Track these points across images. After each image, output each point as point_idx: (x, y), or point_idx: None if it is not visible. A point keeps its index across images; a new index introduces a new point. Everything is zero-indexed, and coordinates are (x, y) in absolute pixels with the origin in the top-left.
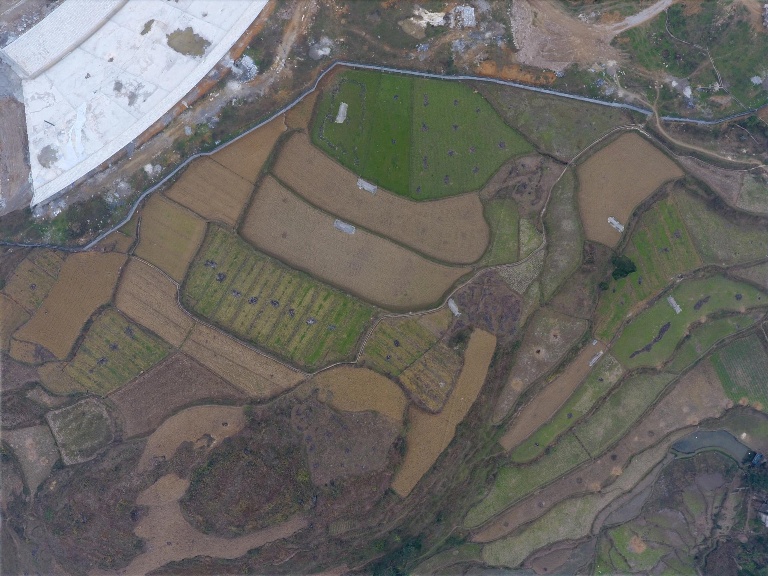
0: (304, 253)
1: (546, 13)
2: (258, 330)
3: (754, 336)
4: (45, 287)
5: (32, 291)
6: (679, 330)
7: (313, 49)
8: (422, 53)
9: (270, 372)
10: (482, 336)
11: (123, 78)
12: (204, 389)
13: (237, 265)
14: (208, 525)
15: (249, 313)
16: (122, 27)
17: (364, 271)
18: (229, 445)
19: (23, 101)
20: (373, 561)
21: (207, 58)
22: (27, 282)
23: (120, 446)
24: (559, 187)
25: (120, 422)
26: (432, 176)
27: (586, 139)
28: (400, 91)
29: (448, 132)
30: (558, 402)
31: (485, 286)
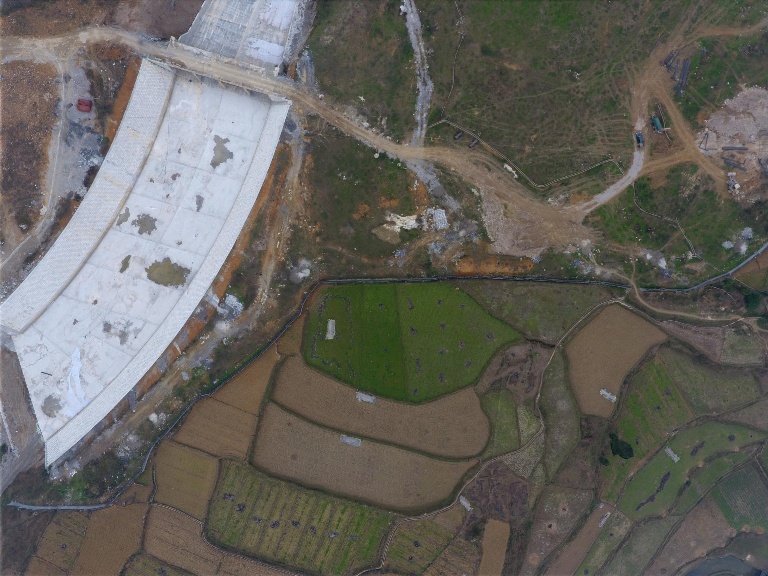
0: (316, 471)
1: (516, 203)
2: (284, 551)
3: (750, 466)
4: (75, 546)
5: (64, 551)
6: (679, 477)
7: (293, 273)
8: (400, 259)
9: None
10: (496, 525)
11: (110, 318)
12: None
13: (254, 494)
14: None
15: (273, 537)
16: (100, 268)
17: (375, 479)
18: None
19: None
20: None
21: (190, 289)
22: (57, 544)
23: None
24: (550, 370)
25: None
26: (427, 377)
27: (570, 319)
28: (384, 299)
29: (436, 332)
30: (574, 565)
31: (492, 477)
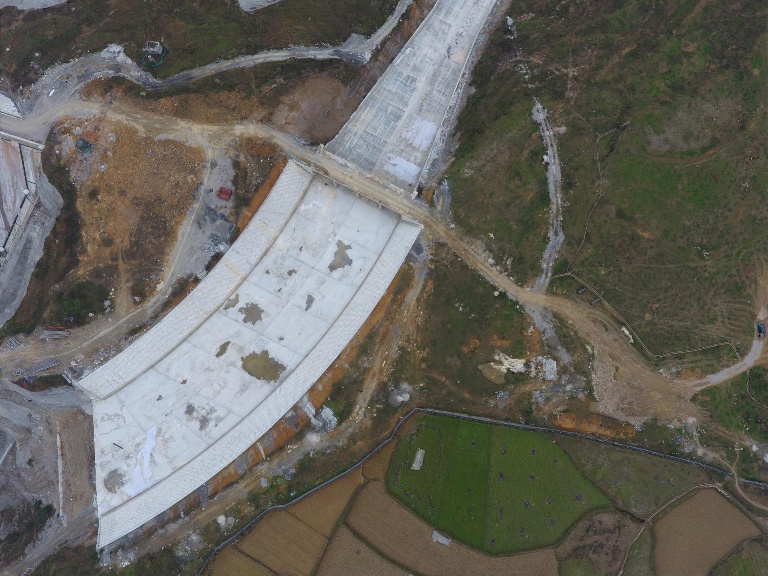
0: None
1: (627, 368)
2: None
3: None
4: None
5: None
6: None
7: (393, 395)
8: (501, 400)
9: None
10: None
11: (195, 401)
12: None
13: None
14: None
15: None
16: (197, 348)
17: None
18: None
19: (91, 413)
20: None
21: (282, 388)
22: None
23: None
24: (636, 546)
25: None
26: (507, 528)
27: (664, 496)
28: (478, 438)
29: (525, 482)
30: None
31: None
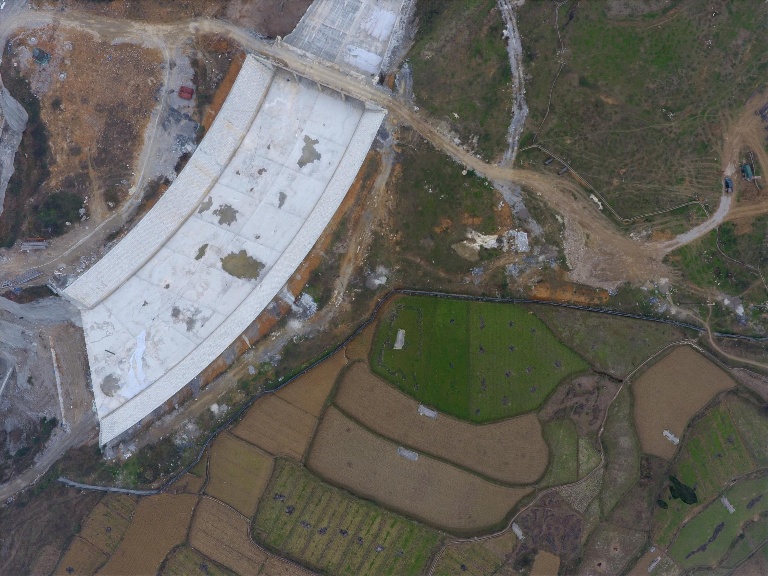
0: (369, 481)
1: (598, 234)
2: (328, 559)
3: None
4: (120, 530)
5: (108, 534)
6: (733, 529)
7: (369, 279)
8: (476, 277)
9: None
10: (546, 557)
11: (180, 304)
12: None
13: (305, 497)
14: None
15: (319, 543)
16: (176, 253)
17: (428, 496)
18: None
19: (81, 325)
20: None
21: (263, 284)
22: (102, 525)
23: None
24: (615, 405)
25: None
26: (490, 398)
27: (640, 356)
28: (456, 315)
29: (505, 353)
30: None
31: (547, 508)
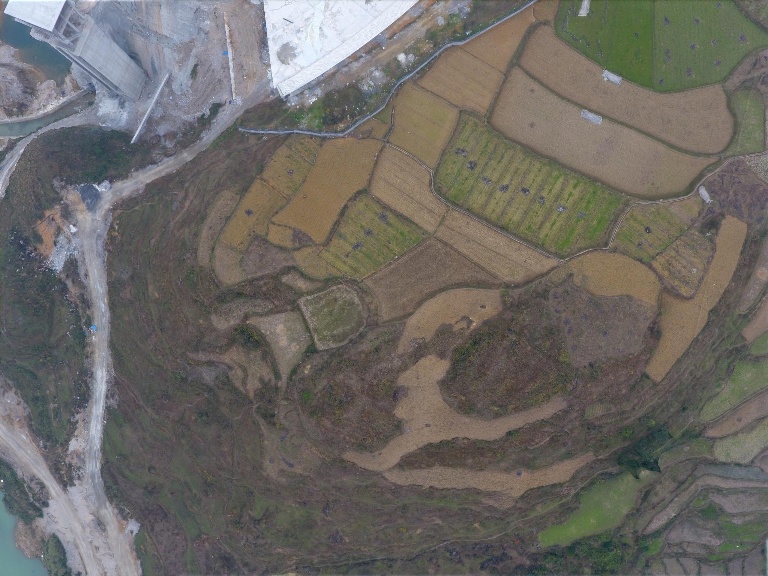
0: (552, 142)
1: None
2: (509, 217)
3: None
4: (302, 173)
5: (290, 176)
6: None
7: None
8: None
9: (523, 258)
10: (733, 223)
11: None
12: (458, 274)
13: (488, 153)
14: (471, 405)
15: (500, 200)
16: None
17: (611, 160)
18: (491, 326)
19: (256, 2)
20: (618, 450)
21: None
22: (285, 168)
23: (378, 329)
24: None
25: (374, 307)
26: (675, 69)
27: None
28: None
29: (690, 26)
30: None
31: (734, 174)
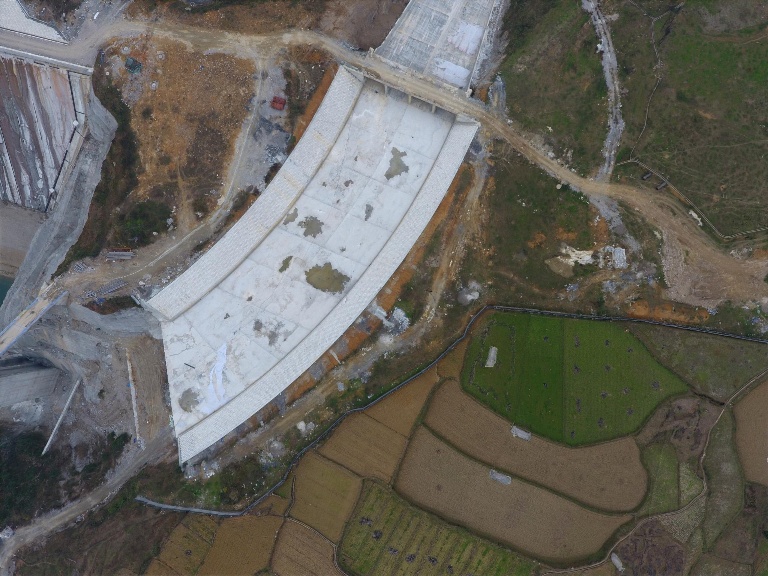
0: (460, 505)
1: (698, 251)
2: None
3: None
4: (200, 553)
5: (187, 557)
6: None
7: (462, 294)
8: (571, 293)
9: None
10: None
11: (263, 317)
12: None
13: (393, 522)
14: None
15: (407, 571)
16: (260, 265)
17: (522, 523)
18: None
19: (159, 338)
20: None
21: (349, 298)
22: (182, 548)
23: None
24: (717, 429)
25: None
26: (586, 419)
27: (742, 378)
28: (550, 332)
29: (600, 373)
30: None
31: (647, 537)
